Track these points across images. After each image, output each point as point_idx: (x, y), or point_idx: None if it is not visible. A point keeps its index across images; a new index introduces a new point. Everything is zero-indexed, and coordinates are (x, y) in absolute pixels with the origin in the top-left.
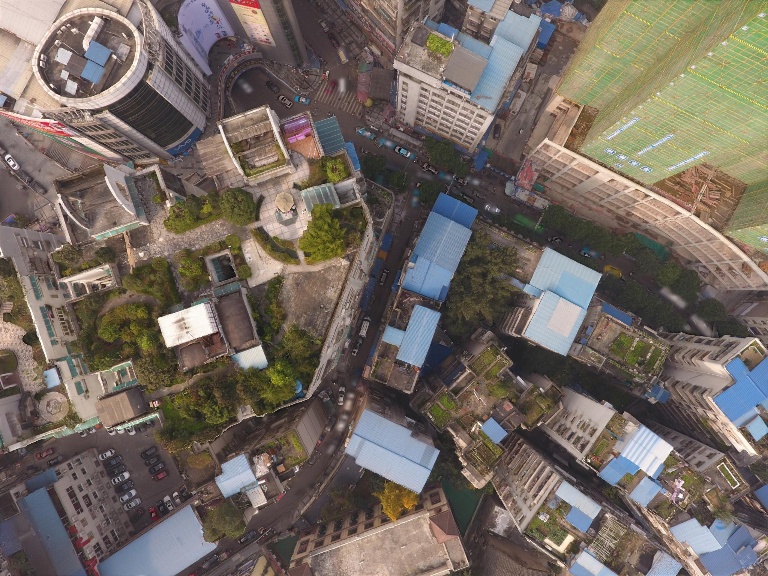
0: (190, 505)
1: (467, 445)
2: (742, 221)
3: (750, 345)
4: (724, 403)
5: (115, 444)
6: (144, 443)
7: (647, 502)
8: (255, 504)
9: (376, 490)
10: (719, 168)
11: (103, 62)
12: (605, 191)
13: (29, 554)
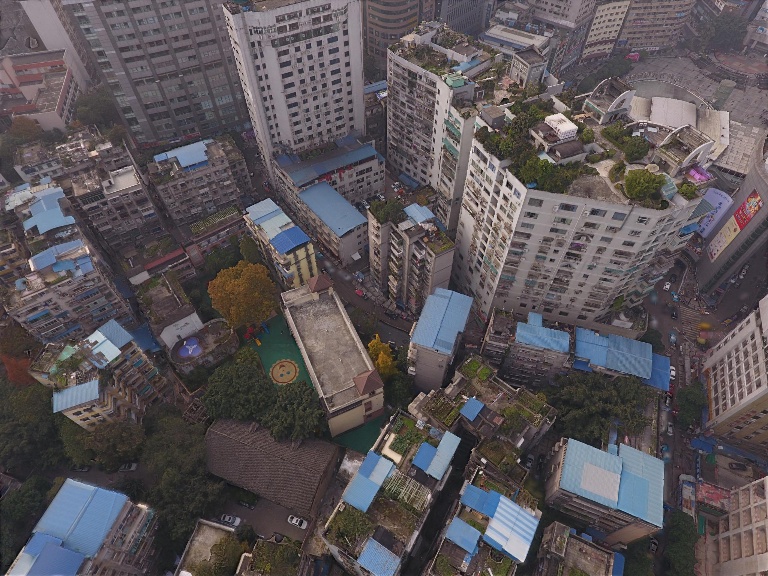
0: None
1: None
2: None
3: None
4: None
5: None
6: None
7: (452, 538)
8: (401, 224)
9: None
10: None
11: None
12: None
13: (336, 150)
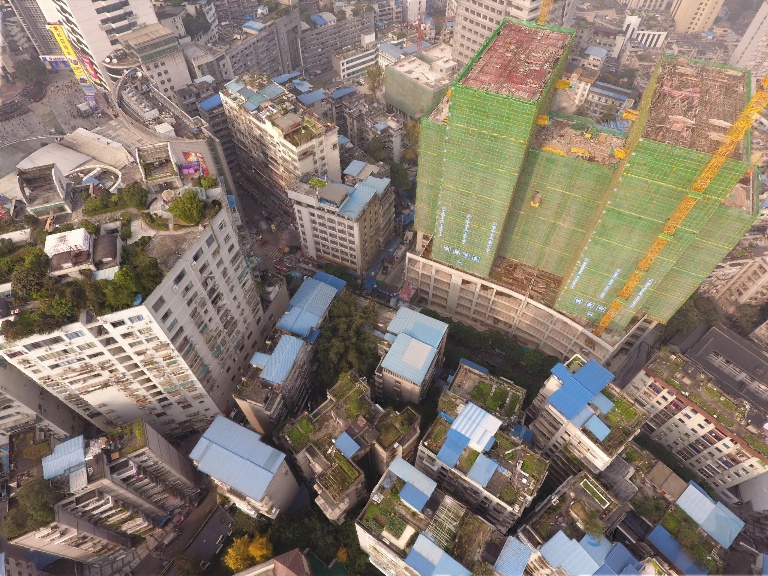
0: (4, 553)
1: None
2: None
3: (574, 360)
4: (558, 402)
5: None
6: None
7: (486, 481)
8: (74, 487)
9: (227, 554)
10: (538, 266)
11: None
12: (466, 297)
13: None
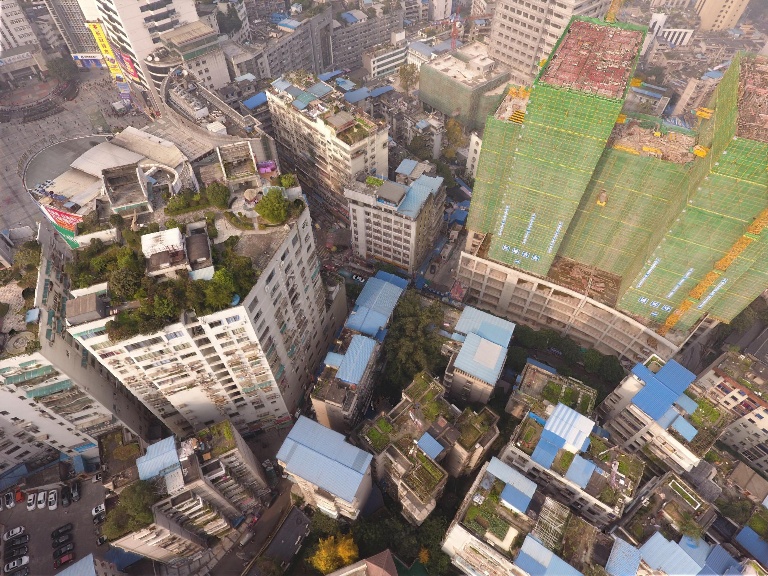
0: None
1: (406, 470)
2: (622, 292)
3: (651, 360)
4: (642, 403)
5: (28, 522)
6: (61, 521)
7: (585, 482)
8: (171, 488)
9: (310, 554)
10: (596, 266)
11: None
12: (520, 297)
13: None
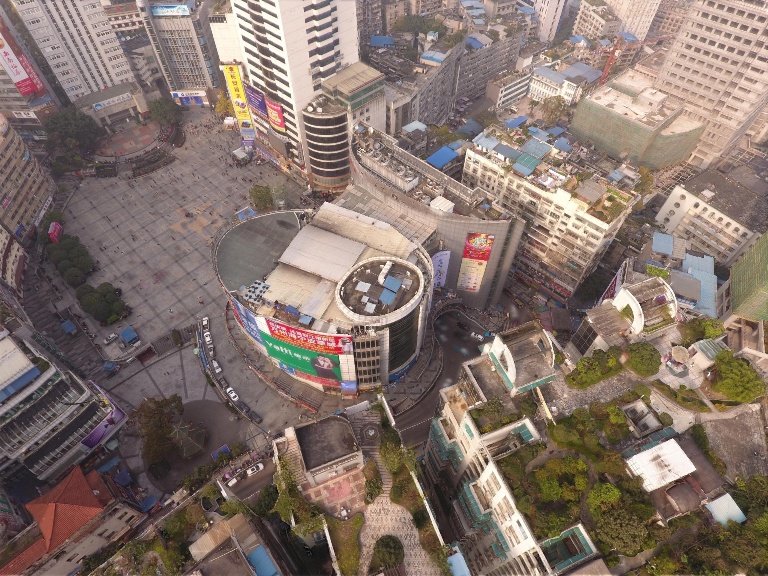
0: None
1: None
2: None
3: None
4: None
5: None
6: None
7: None
8: None
9: None
10: None
11: (396, 289)
12: None
13: None
